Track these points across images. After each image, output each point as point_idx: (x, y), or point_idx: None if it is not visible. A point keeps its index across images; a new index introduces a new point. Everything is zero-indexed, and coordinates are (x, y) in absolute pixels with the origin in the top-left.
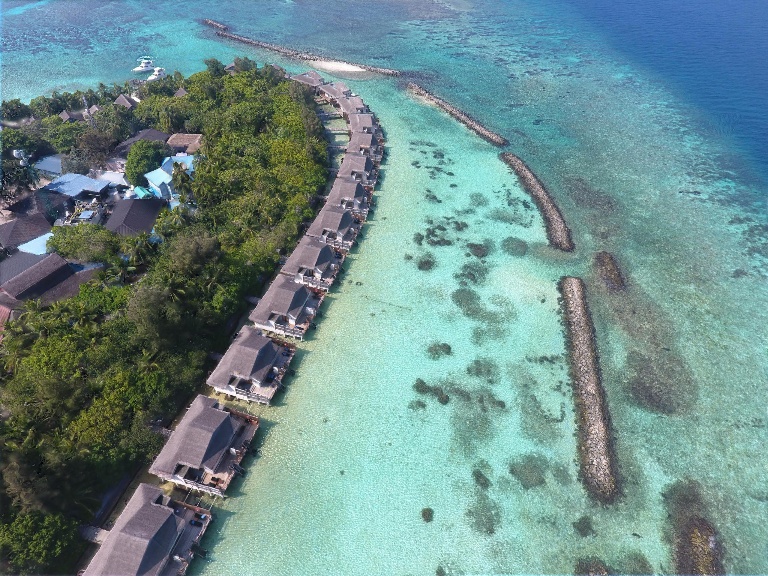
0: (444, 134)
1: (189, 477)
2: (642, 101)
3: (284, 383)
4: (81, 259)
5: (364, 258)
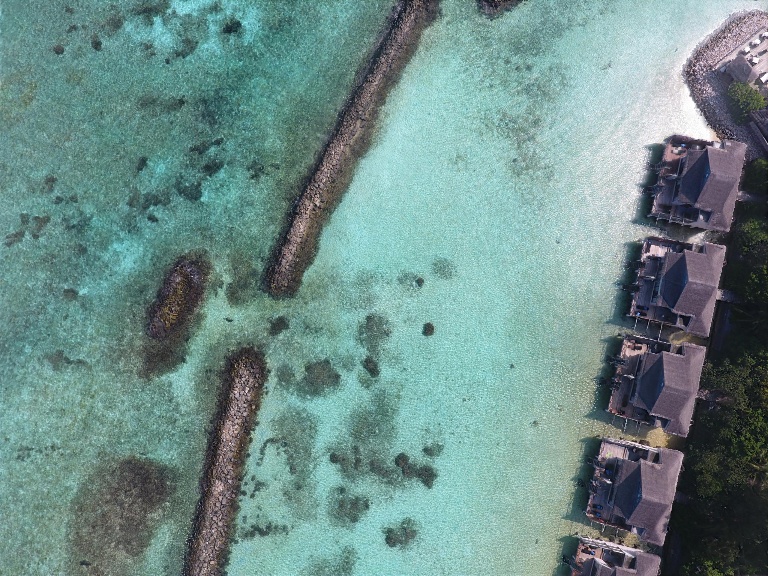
0: None
1: (664, 348)
2: None
3: (588, 469)
4: None
5: None
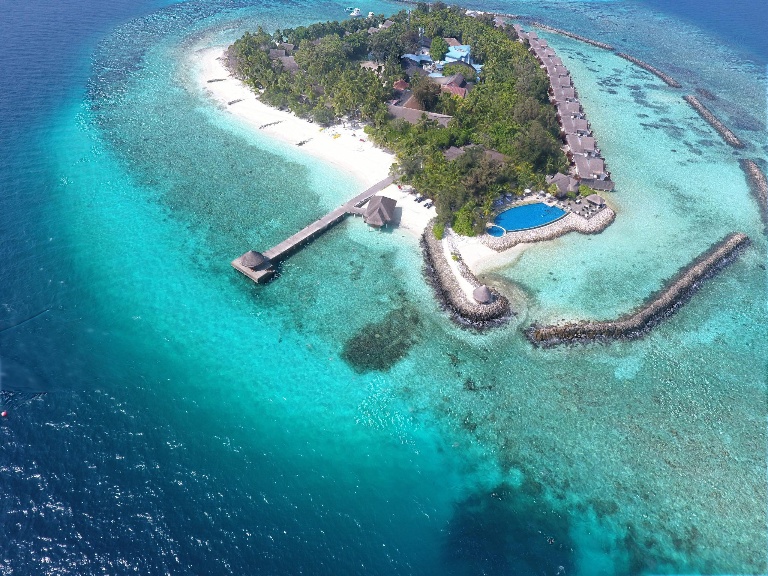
0: (574, 45)
1: None
2: (682, 30)
3: None
4: (468, 77)
5: (579, 90)
